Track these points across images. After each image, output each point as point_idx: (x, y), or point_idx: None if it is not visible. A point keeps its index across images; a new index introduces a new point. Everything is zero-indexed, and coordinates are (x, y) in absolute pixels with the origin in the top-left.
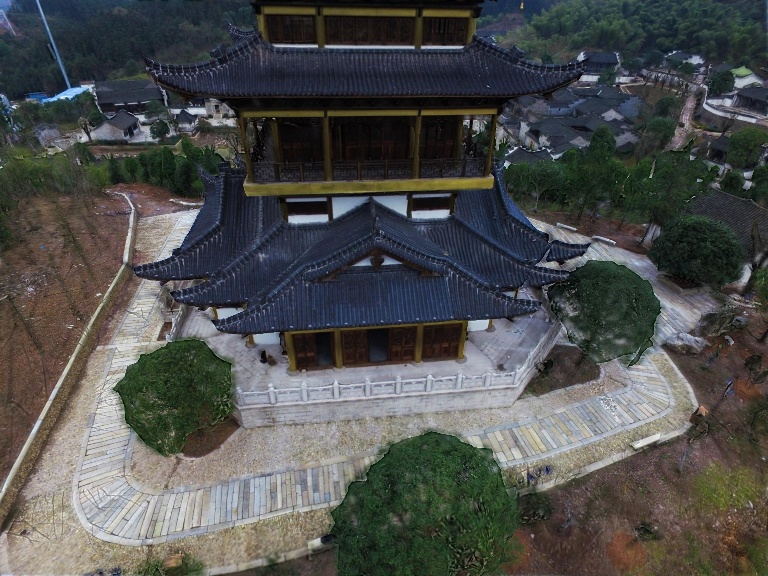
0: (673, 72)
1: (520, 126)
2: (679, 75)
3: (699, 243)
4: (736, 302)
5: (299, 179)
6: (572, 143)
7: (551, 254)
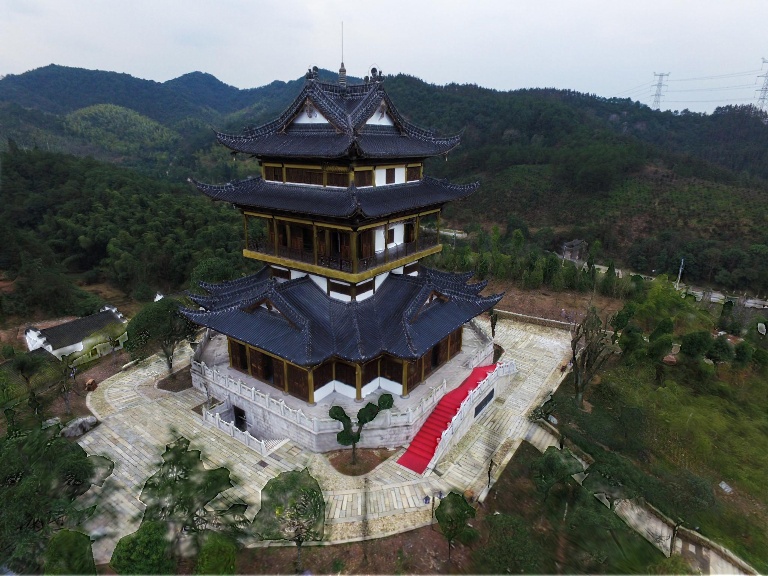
0: None
1: None
2: None
3: None
4: None
5: None
6: None
7: None
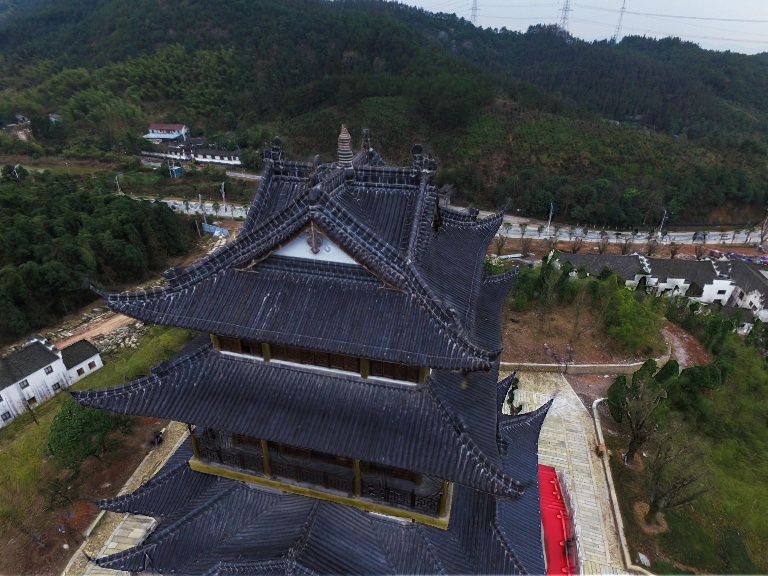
0: None
1: None
2: None
3: None
4: None
5: None
6: None
7: None
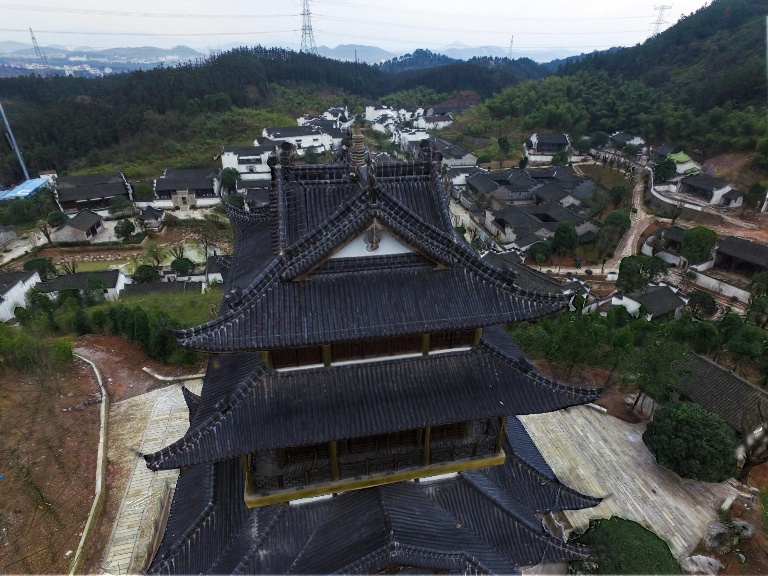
0: (619, 153)
1: (485, 214)
2: (624, 156)
3: (695, 440)
4: (735, 490)
5: (304, 483)
6: (537, 234)
7: (562, 503)
